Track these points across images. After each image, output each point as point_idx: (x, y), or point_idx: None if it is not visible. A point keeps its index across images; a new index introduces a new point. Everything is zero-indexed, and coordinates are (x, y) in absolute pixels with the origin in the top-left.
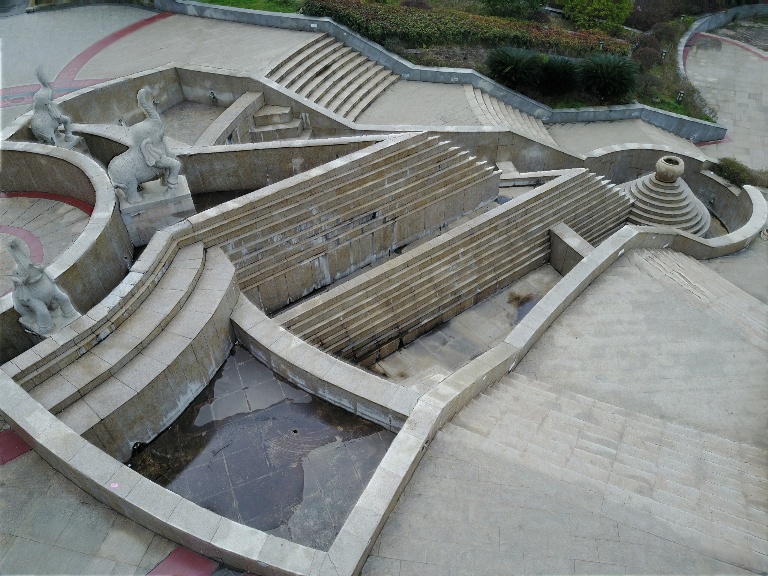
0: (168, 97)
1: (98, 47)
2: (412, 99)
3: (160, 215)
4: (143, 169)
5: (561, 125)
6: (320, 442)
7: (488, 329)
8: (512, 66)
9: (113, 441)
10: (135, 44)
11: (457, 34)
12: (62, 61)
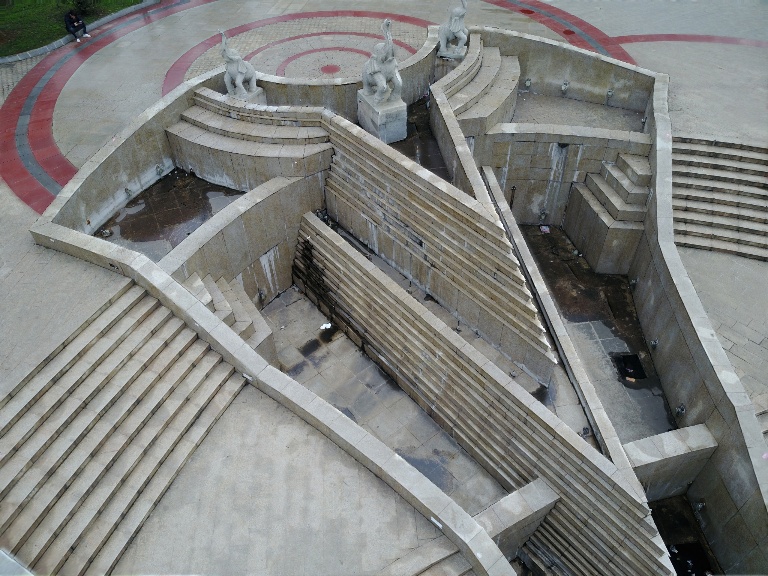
0: (629, 98)
1: (700, 39)
2: None
3: None
4: None
5: None
6: (175, 245)
7: (390, 425)
8: None
9: (182, 153)
10: (721, 53)
11: None
12: (655, 31)
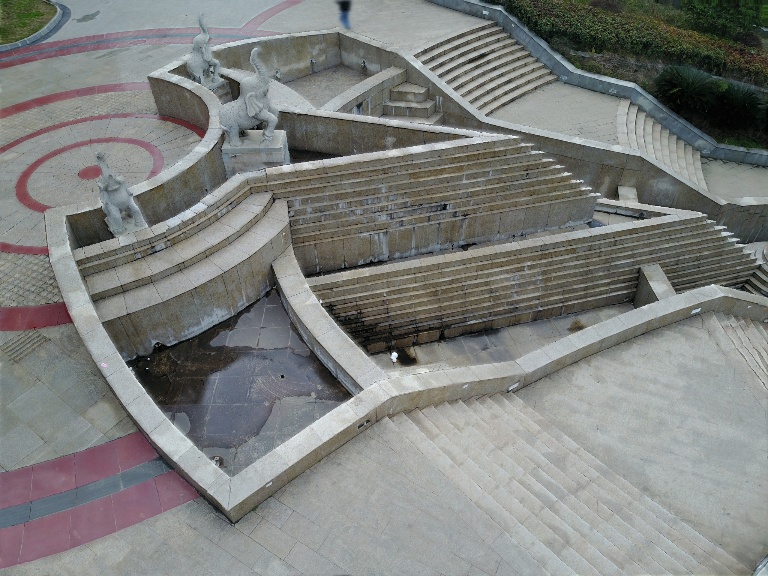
0: (326, 59)
1: (290, 3)
2: (559, 103)
3: (253, 161)
4: (245, 118)
5: (722, 162)
6: (297, 392)
7: (534, 348)
8: (680, 88)
9: (137, 334)
10: (320, 5)
11: (637, 44)
12: (256, 11)
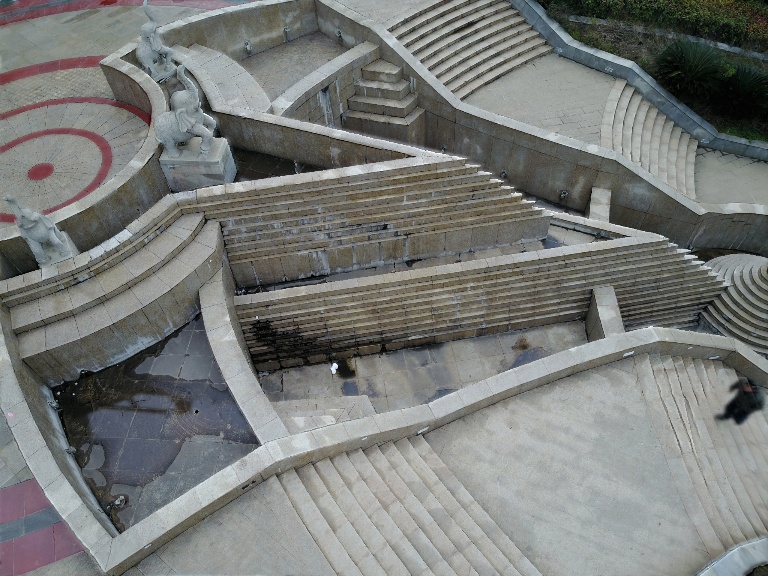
0: (302, 25)
1: None
2: (547, 82)
3: (192, 172)
4: (178, 132)
5: (721, 154)
6: (207, 431)
7: (473, 367)
8: (681, 71)
9: (60, 365)
10: None
11: (647, 9)
12: None
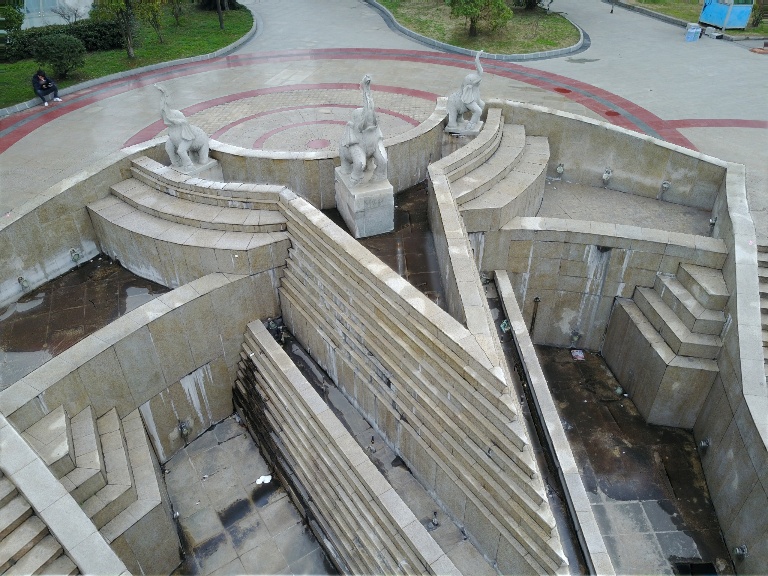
0: (691, 192)
1: None
2: None
3: (344, 196)
4: None
5: None
6: None
7: None
8: None
9: (105, 236)
10: None
11: None
12: (720, 115)
